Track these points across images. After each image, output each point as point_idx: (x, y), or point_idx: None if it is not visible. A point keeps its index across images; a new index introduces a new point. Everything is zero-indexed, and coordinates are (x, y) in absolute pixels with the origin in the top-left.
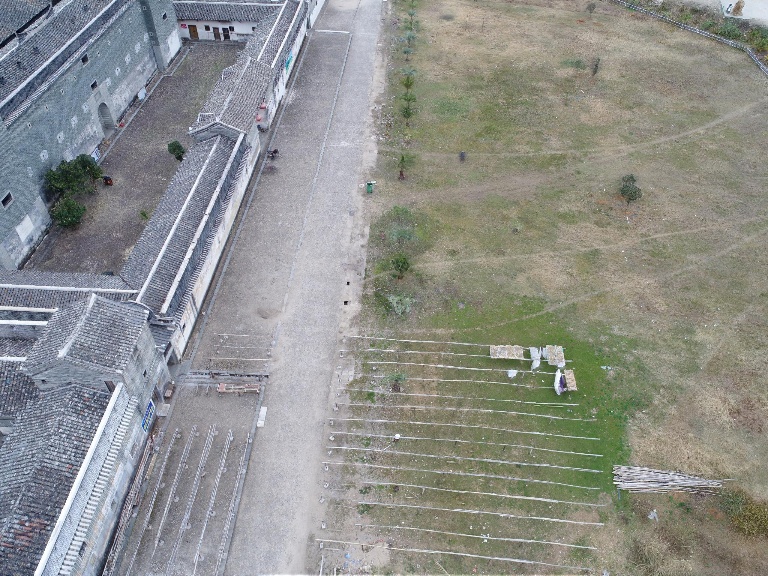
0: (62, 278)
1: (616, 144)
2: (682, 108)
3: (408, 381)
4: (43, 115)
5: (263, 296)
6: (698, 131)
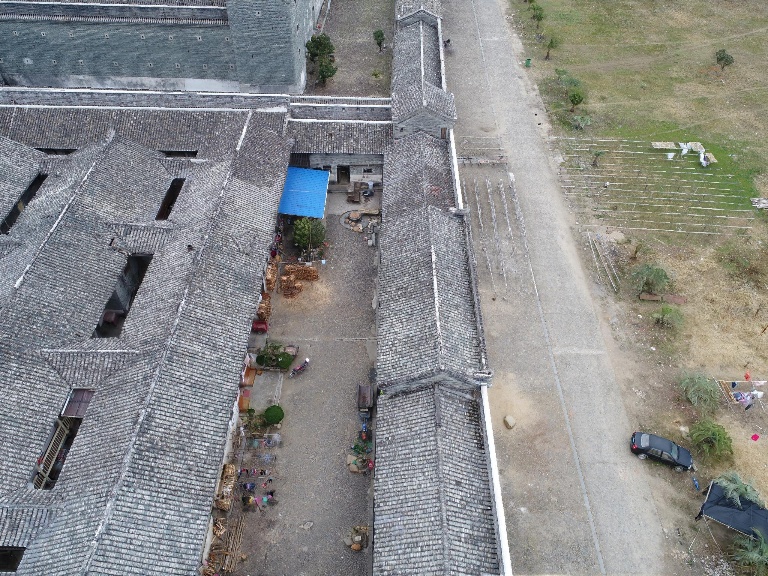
0: None
1: (701, 39)
2: (745, 17)
3: (600, 162)
4: (301, 1)
5: (480, 121)
6: (761, 31)
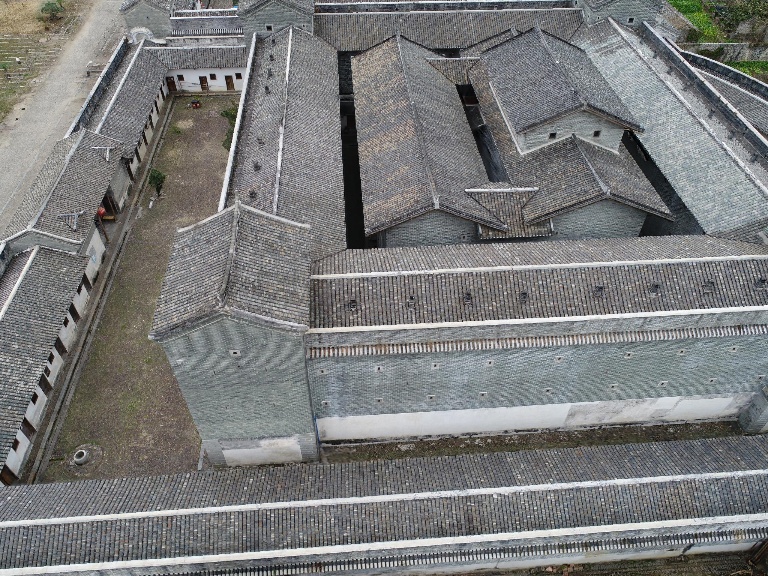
0: (202, 61)
1: None
2: None
3: (1, 81)
4: None
5: None
6: None
